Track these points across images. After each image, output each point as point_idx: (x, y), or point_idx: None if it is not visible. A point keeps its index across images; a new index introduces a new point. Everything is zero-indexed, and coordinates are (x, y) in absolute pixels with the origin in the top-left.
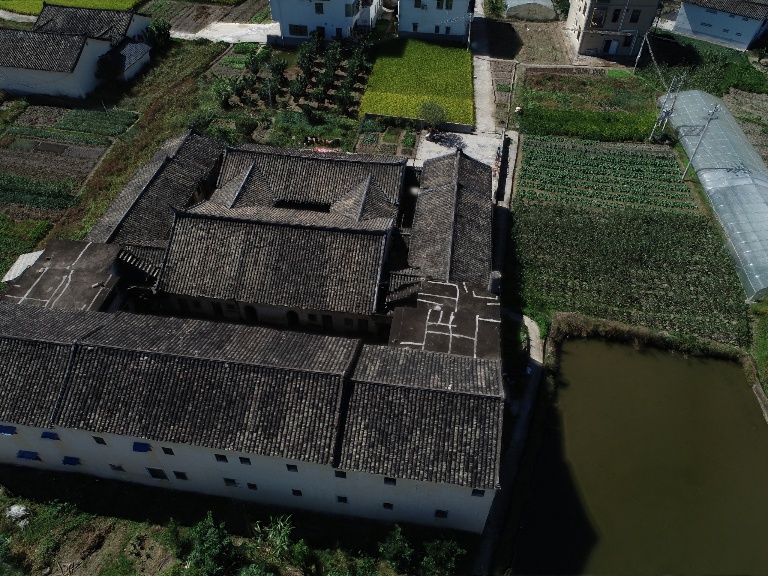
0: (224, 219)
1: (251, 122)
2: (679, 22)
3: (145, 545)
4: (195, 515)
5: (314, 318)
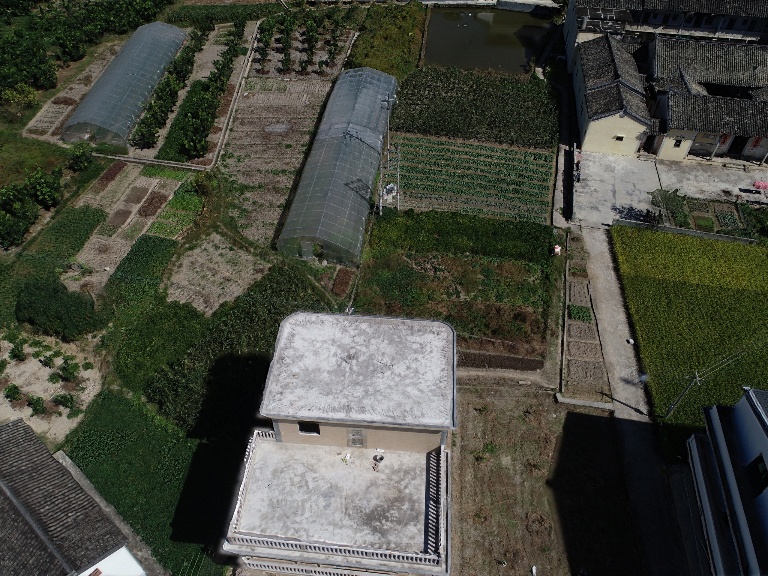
0: (767, 47)
1: None
2: (132, 555)
3: None
4: None
5: None
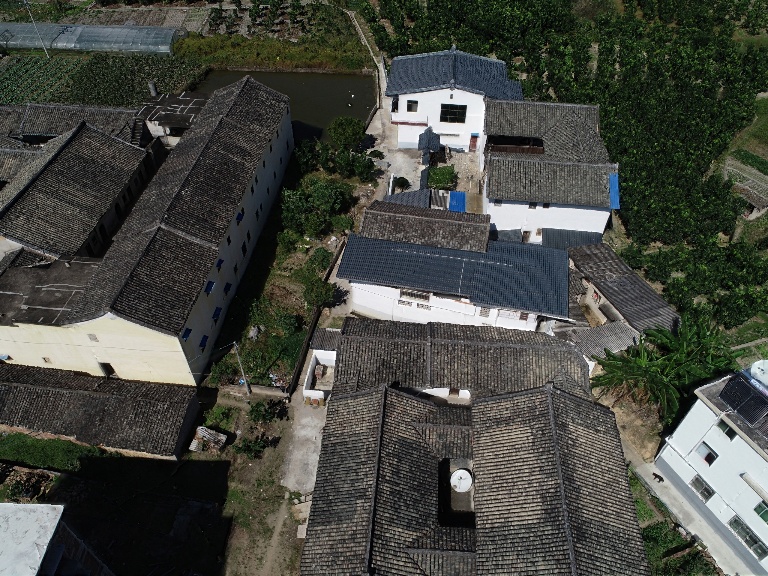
0: (16, 199)
1: None
2: None
3: (285, 267)
4: (270, 246)
5: (125, 198)
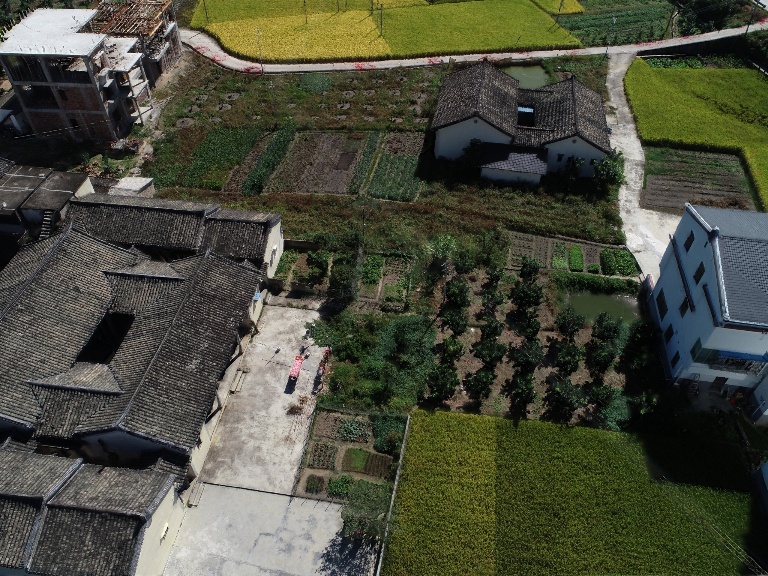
0: None
1: (339, 279)
2: None
3: None
4: None
5: None
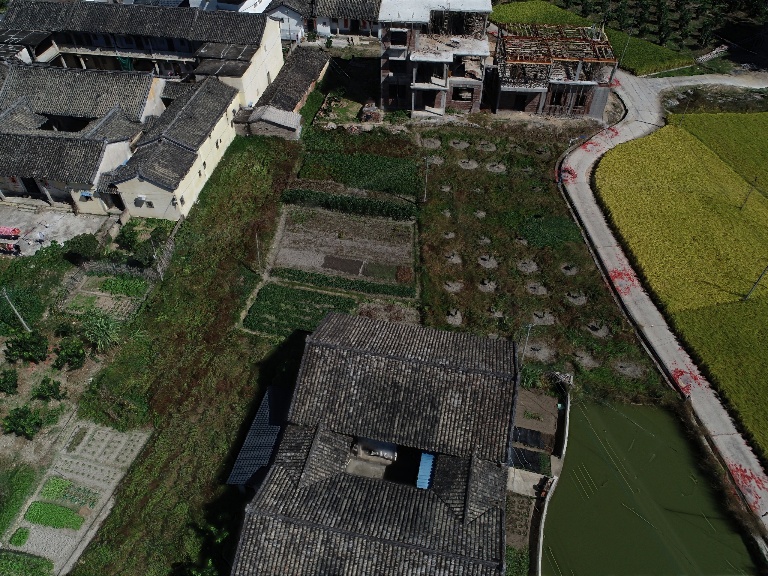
0: None
1: None
2: None
3: None
4: None
5: None
